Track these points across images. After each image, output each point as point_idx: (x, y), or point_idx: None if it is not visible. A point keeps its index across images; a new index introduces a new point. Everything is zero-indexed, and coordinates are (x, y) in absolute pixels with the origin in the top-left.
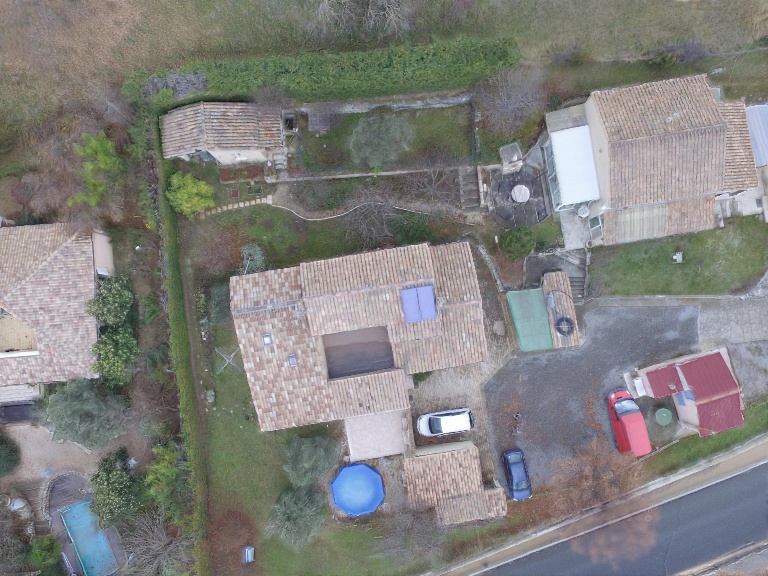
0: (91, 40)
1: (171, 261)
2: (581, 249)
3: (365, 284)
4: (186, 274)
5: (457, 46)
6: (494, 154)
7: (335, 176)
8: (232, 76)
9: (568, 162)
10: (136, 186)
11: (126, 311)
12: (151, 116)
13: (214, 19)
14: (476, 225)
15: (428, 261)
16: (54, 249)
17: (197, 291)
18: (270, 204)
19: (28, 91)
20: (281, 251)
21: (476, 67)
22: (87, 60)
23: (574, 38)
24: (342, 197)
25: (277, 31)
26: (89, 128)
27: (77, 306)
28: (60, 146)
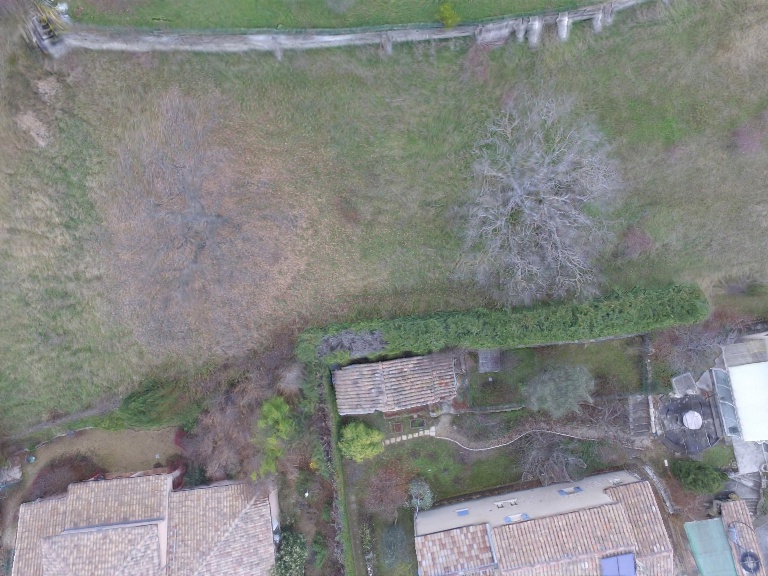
0: (256, 292)
1: (345, 512)
2: (755, 472)
3: (563, 553)
4: (350, 510)
5: (643, 301)
6: (670, 389)
7: (503, 410)
8: (413, 338)
9: (750, 399)
10: (310, 442)
11: (303, 568)
12: (323, 370)
13: (383, 269)
14: (645, 449)
15: (625, 525)
16: (234, 517)
17: (362, 527)
18: (433, 436)
19: (193, 345)
20: (446, 483)
21: (666, 324)
22: (252, 311)
23: (748, 269)
24: (507, 427)
25: (445, 275)
26: (265, 392)
27: (259, 574)
28: (236, 412)
